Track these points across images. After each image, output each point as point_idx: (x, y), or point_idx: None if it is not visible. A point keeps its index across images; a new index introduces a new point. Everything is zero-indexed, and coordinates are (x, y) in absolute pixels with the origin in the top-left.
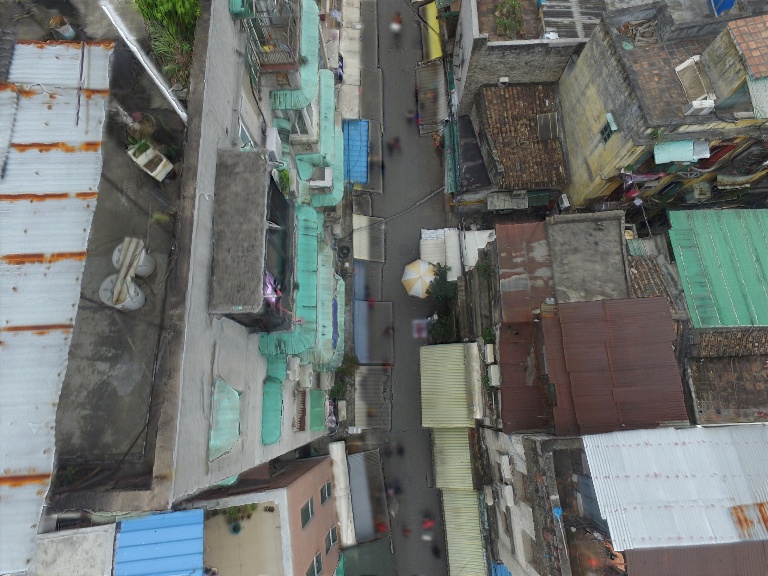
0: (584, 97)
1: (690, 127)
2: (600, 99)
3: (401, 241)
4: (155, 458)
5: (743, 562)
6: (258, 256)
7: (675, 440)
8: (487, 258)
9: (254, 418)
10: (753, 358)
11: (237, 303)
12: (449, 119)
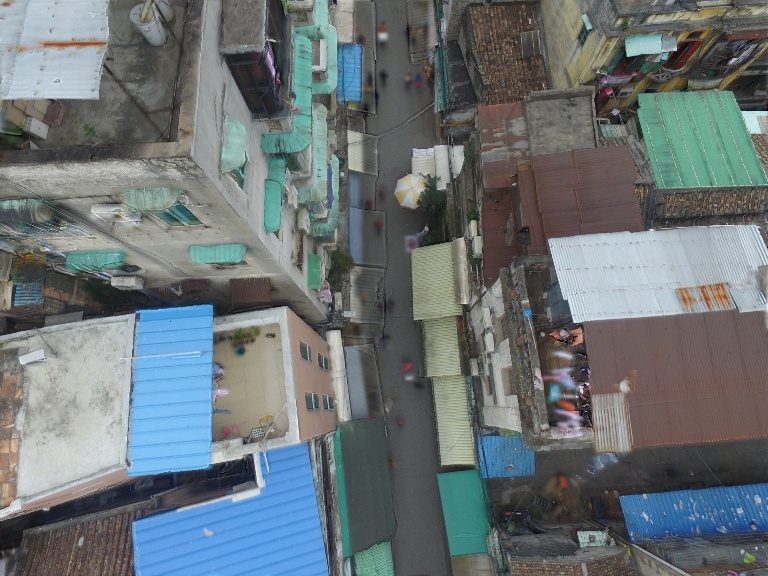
0: (563, 7)
1: (657, 18)
2: (577, 4)
3: (394, 165)
4: (179, 120)
5: (686, 330)
6: (260, 9)
7: (630, 240)
8: (471, 146)
9: (257, 198)
10: (713, 220)
11: (243, 43)
12: (438, 45)
